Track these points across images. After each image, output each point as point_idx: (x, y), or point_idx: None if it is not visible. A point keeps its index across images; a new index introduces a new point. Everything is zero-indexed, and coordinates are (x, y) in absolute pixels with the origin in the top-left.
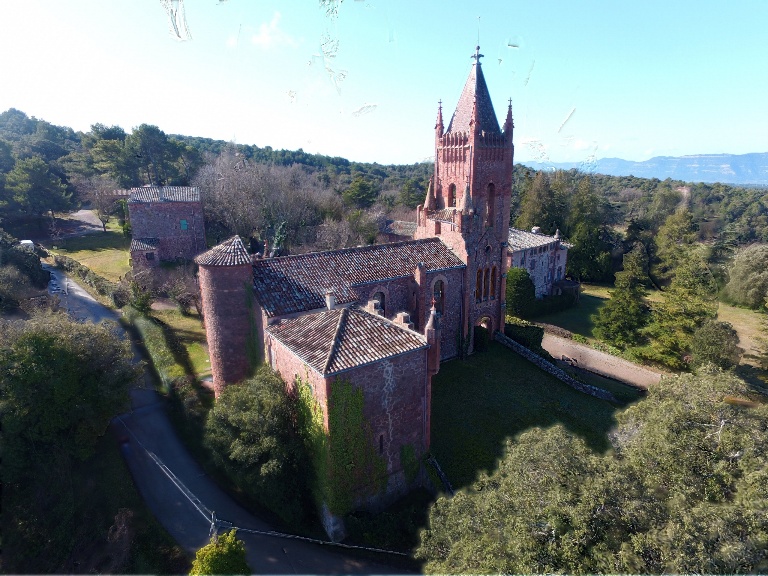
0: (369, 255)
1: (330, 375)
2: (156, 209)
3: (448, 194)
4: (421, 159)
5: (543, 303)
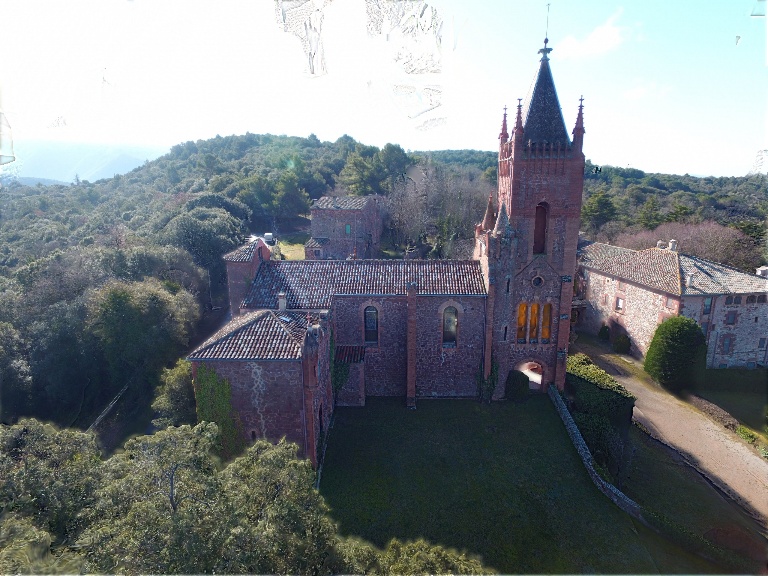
0: (380, 269)
1: (191, 359)
2: (329, 215)
3: None
4: None
5: (734, 374)
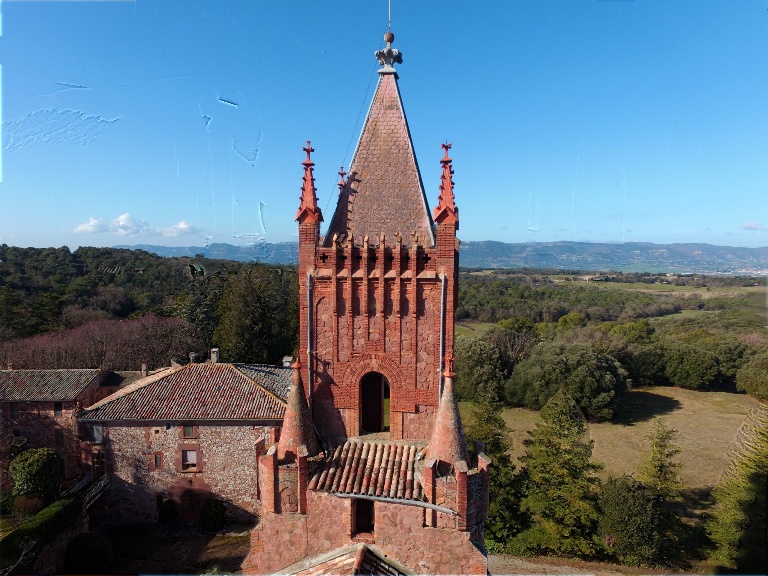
0: None
1: None
2: None
3: (358, 401)
4: (123, 273)
5: None
